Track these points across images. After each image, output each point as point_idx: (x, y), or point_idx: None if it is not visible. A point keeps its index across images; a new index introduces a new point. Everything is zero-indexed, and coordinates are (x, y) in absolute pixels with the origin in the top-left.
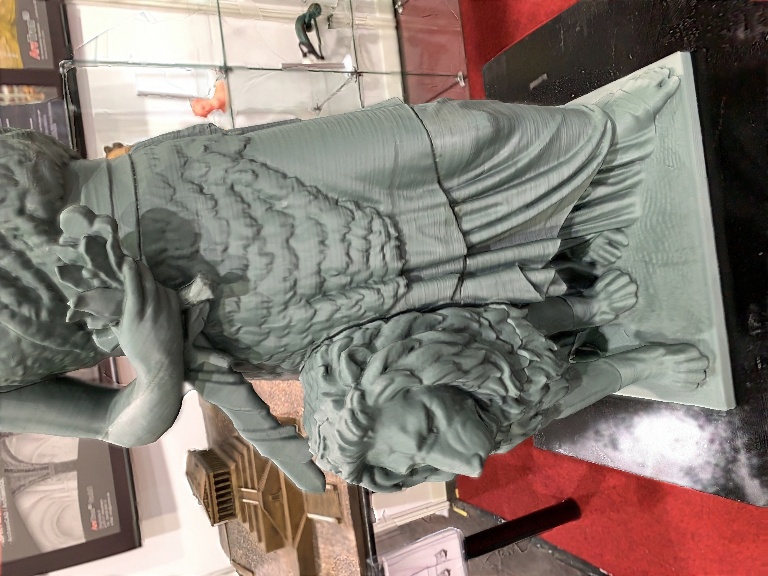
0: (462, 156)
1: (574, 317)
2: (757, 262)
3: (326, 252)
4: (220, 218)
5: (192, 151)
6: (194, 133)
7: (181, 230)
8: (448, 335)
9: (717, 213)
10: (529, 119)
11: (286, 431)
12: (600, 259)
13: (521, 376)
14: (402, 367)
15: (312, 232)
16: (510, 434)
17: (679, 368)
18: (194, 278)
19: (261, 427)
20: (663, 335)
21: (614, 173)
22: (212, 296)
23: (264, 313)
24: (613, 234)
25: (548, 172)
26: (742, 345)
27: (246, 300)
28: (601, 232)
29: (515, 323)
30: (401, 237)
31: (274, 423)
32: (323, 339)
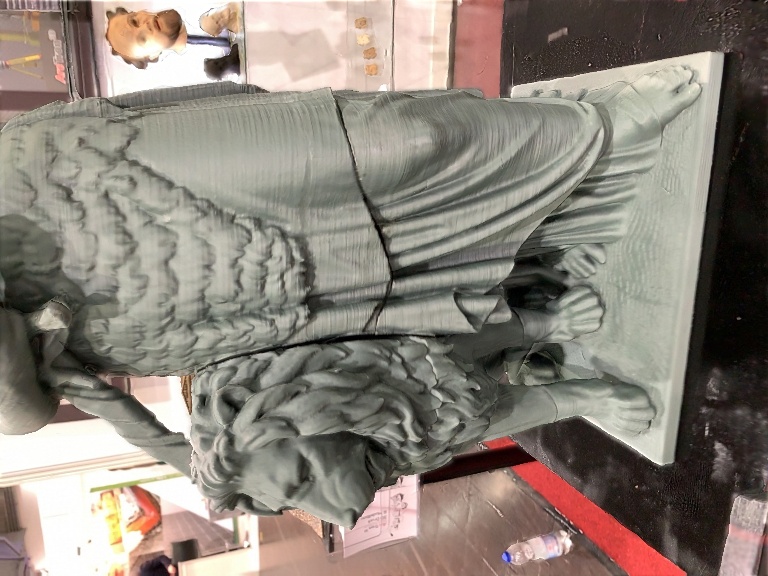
0: (393, 176)
1: (524, 336)
2: (733, 326)
3: (212, 278)
4: (87, 232)
5: (65, 143)
6: (80, 111)
7: (40, 243)
8: (343, 380)
9: (707, 256)
10: (493, 127)
11: (172, 439)
12: (572, 271)
13: (430, 417)
14: (280, 414)
15: (196, 255)
16: (413, 466)
17: (622, 414)
18: (55, 296)
19: (143, 435)
20: (618, 370)
21: (603, 183)
22: (65, 326)
23: (137, 336)
24: (590, 248)
25: (510, 189)
26: (695, 405)
27: (115, 323)
28: (577, 244)
29: (434, 361)
30: (310, 261)
31: (158, 431)
32: (208, 363)
